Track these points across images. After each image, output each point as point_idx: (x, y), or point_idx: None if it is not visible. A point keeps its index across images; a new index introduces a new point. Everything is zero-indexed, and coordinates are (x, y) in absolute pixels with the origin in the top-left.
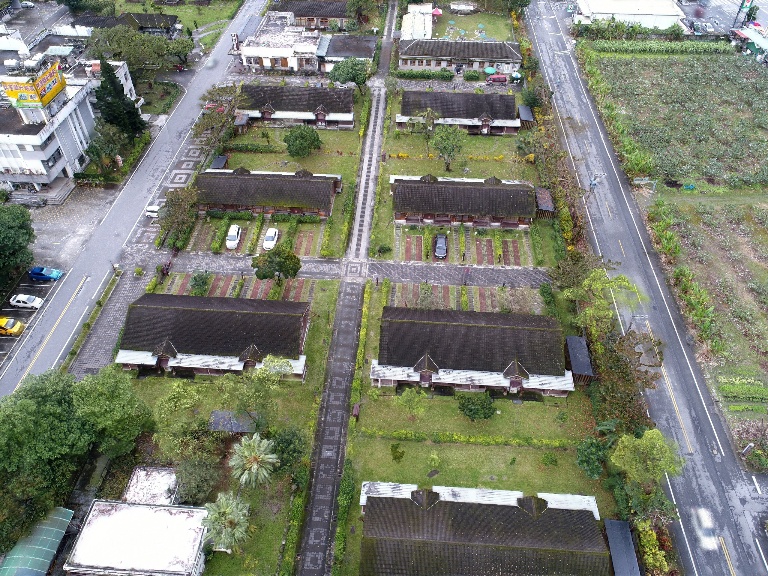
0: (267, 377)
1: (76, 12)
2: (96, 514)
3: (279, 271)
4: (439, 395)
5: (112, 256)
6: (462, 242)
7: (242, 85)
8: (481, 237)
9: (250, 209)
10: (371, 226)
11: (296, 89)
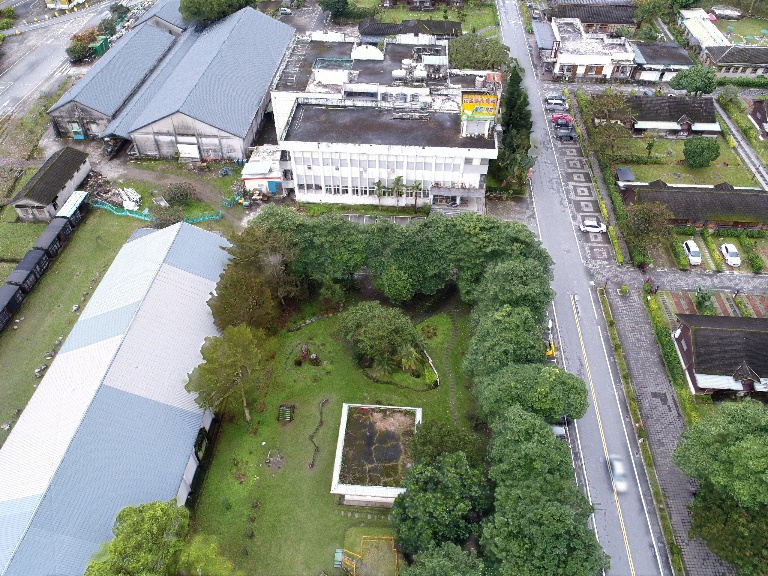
0: None
1: (338, 19)
2: None
3: None
4: None
5: (580, 273)
6: None
7: (597, 94)
8: None
9: (689, 223)
10: None
11: (654, 98)
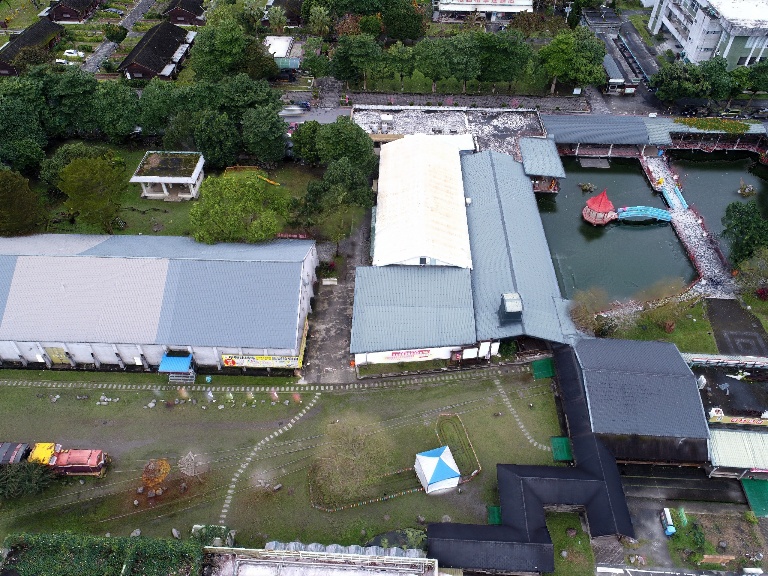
0: None
1: None
2: None
3: None
4: None
5: None
6: (116, 5)
7: None
8: None
9: None
10: None
11: None
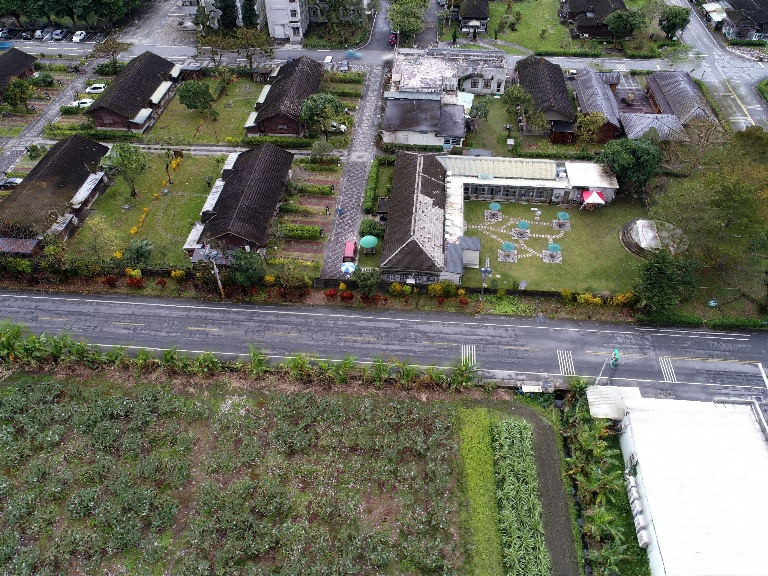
0: None
1: None
2: None
3: None
4: None
5: None
6: None
7: (303, 55)
8: None
9: None
10: None
11: None
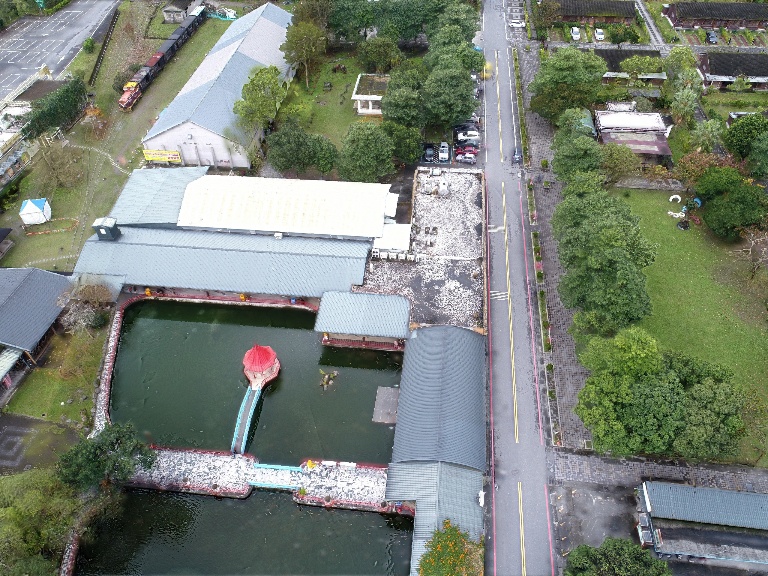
0: (682, 52)
1: None
2: (600, 115)
3: (628, 39)
4: (746, 93)
5: (504, 43)
6: (726, 34)
7: None
8: (735, 34)
9: None
10: (658, 31)
11: None
